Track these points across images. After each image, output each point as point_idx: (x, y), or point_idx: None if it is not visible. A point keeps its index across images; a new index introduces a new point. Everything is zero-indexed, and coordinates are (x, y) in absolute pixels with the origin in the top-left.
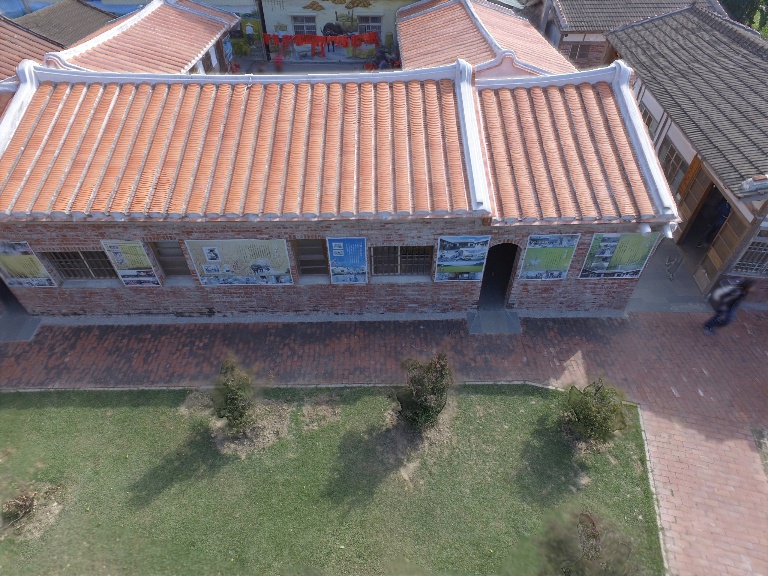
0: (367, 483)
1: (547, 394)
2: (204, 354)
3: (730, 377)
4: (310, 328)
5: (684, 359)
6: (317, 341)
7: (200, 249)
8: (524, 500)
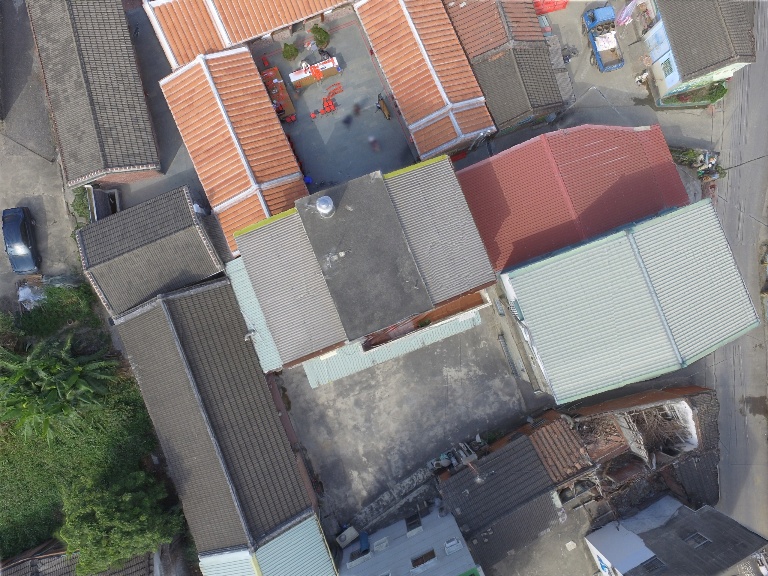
0: None
1: None
2: None
3: None
4: None
5: None
6: None
7: None
8: None
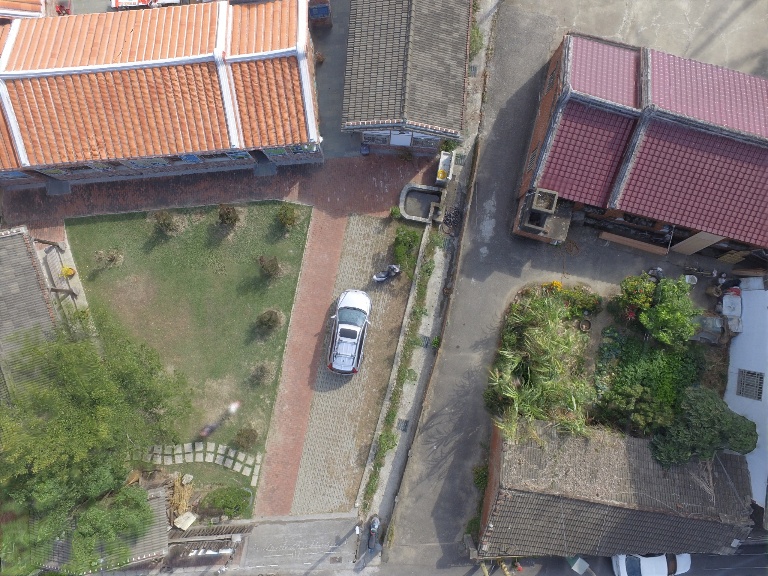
0: (217, 242)
1: (282, 203)
2: (146, 195)
3: (352, 191)
4: (187, 178)
5: (338, 183)
6: (191, 185)
7: (127, 162)
8: (267, 243)
